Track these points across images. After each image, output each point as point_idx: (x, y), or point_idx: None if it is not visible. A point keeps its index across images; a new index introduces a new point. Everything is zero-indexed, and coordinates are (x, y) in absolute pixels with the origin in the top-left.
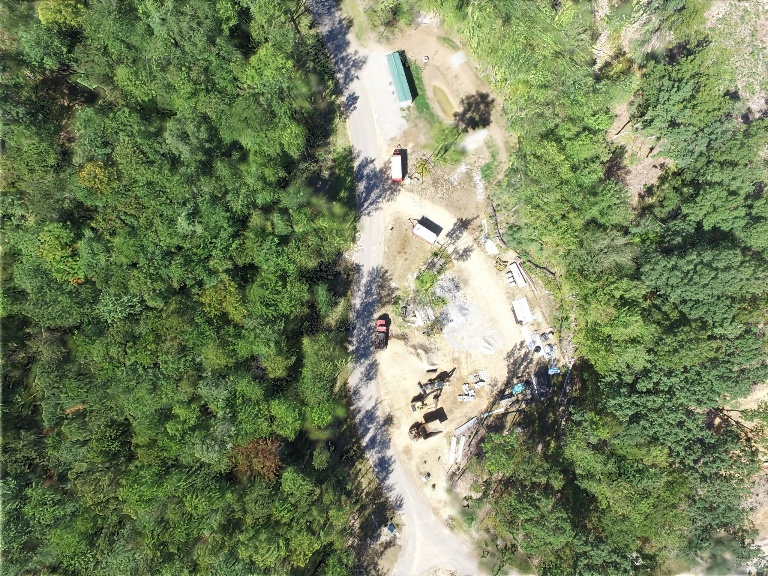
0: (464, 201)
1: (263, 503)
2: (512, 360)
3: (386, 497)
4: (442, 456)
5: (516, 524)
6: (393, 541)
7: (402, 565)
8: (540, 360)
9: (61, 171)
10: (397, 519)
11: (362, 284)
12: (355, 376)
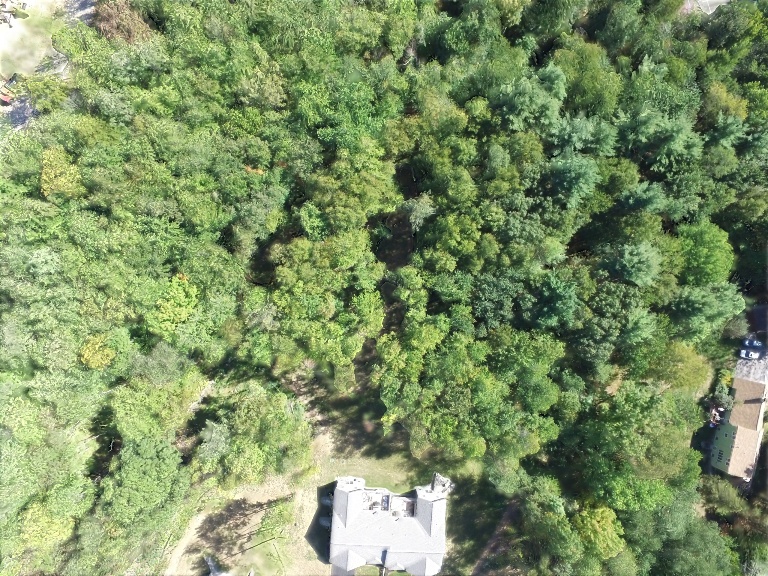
0: None
1: None
2: None
3: None
4: None
5: None
6: None
7: None
8: None
9: None
10: None
11: None
12: (62, 70)
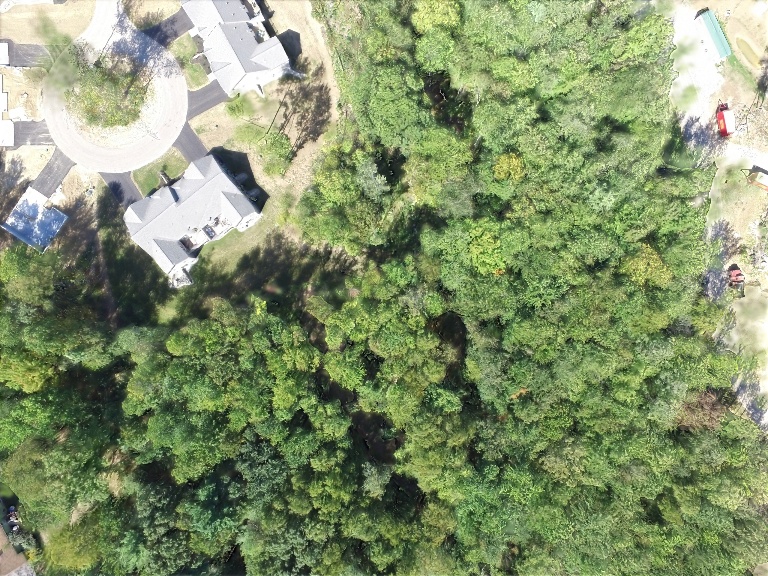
0: None
1: (718, 452)
2: None
3: (764, 436)
4: None
5: None
6: None
7: None
8: None
9: (470, 168)
10: None
11: (708, 239)
12: None
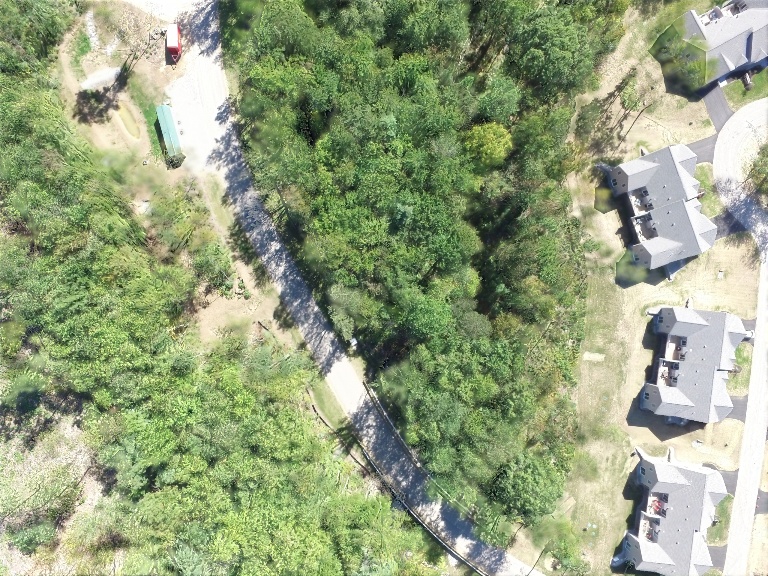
0: (107, 10)
1: None
2: None
3: None
4: None
5: None
6: None
7: None
8: None
9: None
10: None
11: None
12: None
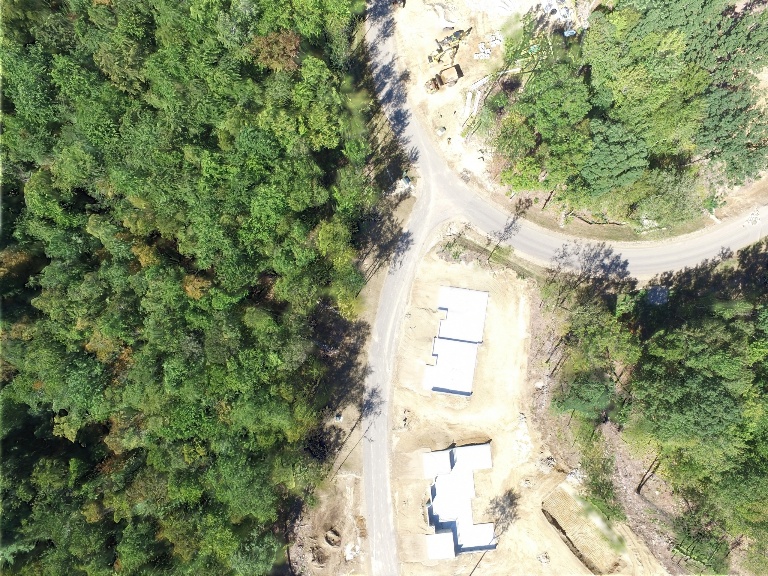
0: None
1: (283, 85)
2: (528, 22)
3: (401, 150)
4: (458, 111)
5: (533, 102)
6: (408, 193)
7: (416, 216)
8: (556, 23)
9: None
10: (412, 171)
11: None
12: (373, 33)
